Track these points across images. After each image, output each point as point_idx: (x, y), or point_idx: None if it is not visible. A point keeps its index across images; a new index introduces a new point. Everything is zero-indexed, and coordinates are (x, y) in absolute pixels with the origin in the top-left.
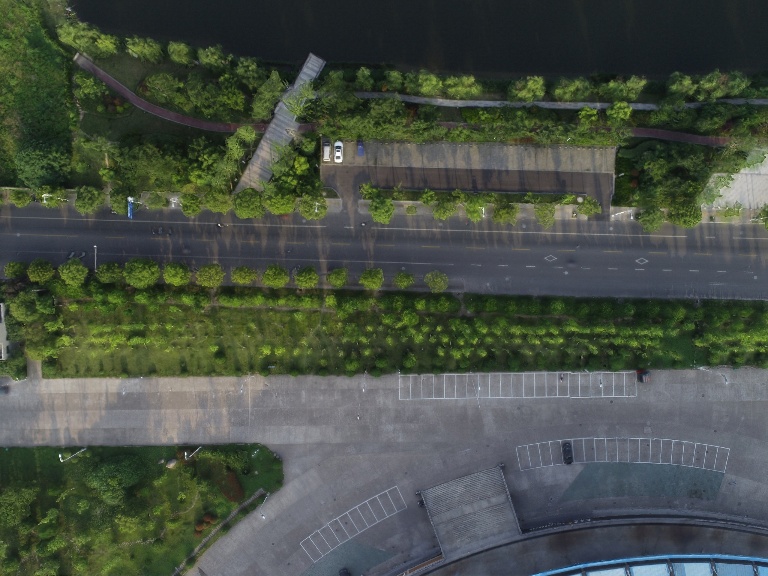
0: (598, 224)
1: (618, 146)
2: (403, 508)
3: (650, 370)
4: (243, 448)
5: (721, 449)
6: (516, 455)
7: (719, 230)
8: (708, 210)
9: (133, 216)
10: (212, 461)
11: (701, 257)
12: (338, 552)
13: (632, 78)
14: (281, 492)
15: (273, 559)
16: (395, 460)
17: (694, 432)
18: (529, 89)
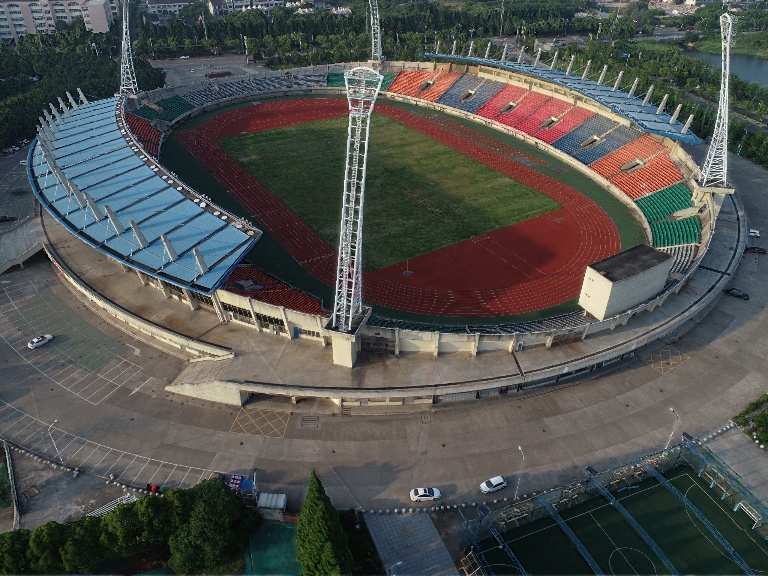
0: None
1: None
2: None
3: None
4: None
5: None
6: None
7: None
8: None
9: None
10: None
11: None
12: None
13: None
14: None
15: None
16: None
17: None
18: None
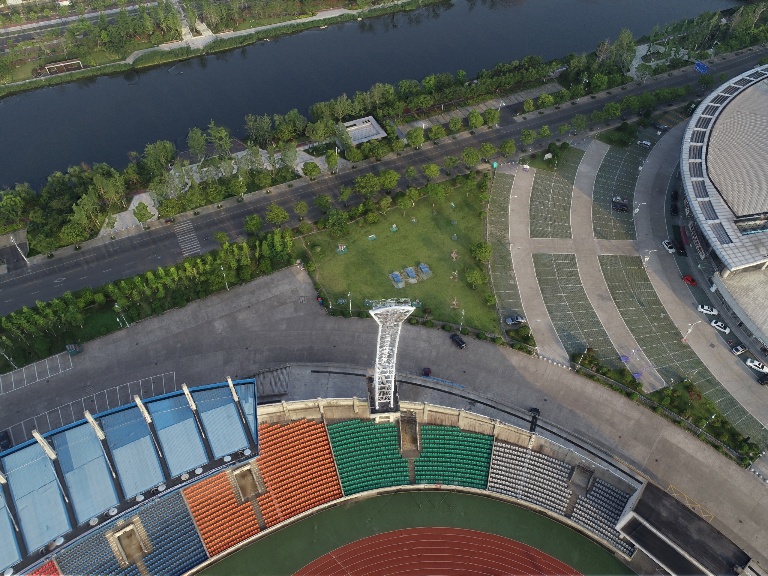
0: (17, 272)
1: (28, 227)
2: None
3: (82, 345)
4: None
5: (166, 375)
6: None
7: (121, 242)
8: (108, 235)
9: None
10: None
11: (110, 261)
12: None
13: (16, 184)
14: None
15: None
16: None
17: (136, 373)
18: None
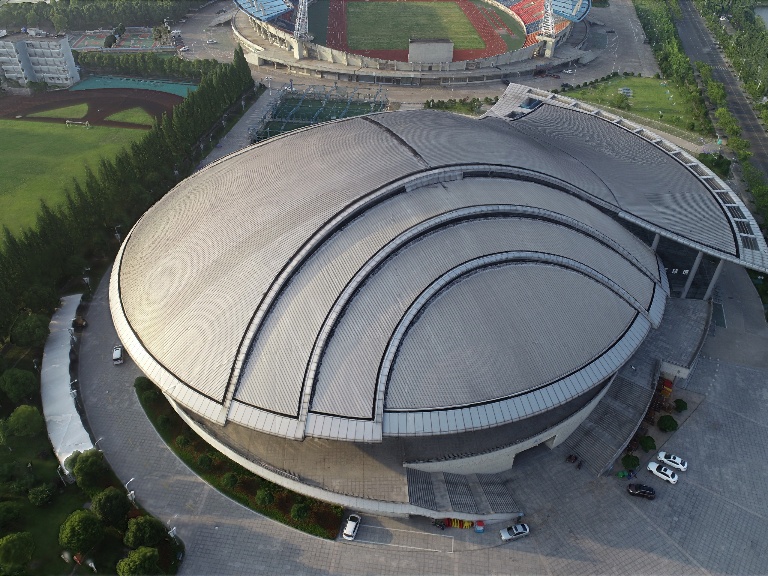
0: None
1: None
2: None
3: None
4: (608, 4)
5: None
6: None
7: None
8: None
9: (688, 2)
10: None
11: None
12: None
13: None
14: None
15: None
16: None
17: (622, 47)
18: (767, 30)
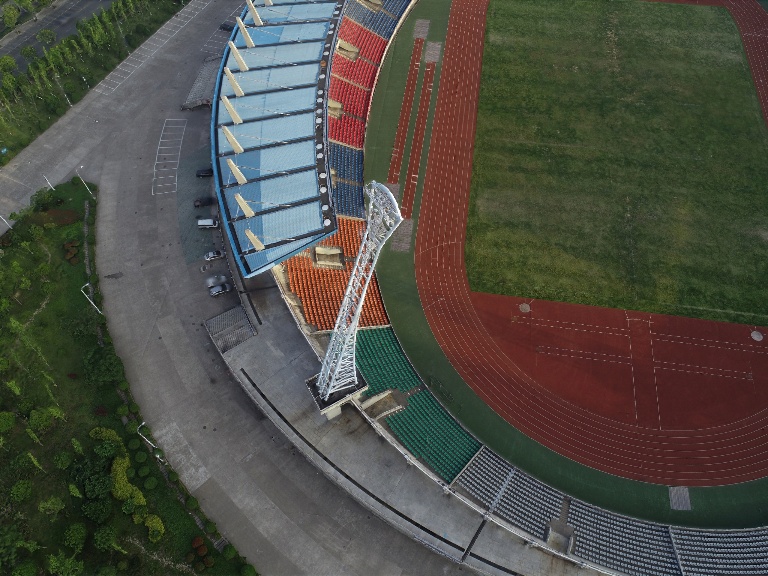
0: None
1: None
2: (186, 122)
3: None
4: None
5: None
6: (206, 52)
7: None
8: None
9: None
10: (24, 214)
11: None
12: (182, 173)
13: None
14: (102, 190)
15: (148, 218)
16: (147, 113)
17: None
18: None
